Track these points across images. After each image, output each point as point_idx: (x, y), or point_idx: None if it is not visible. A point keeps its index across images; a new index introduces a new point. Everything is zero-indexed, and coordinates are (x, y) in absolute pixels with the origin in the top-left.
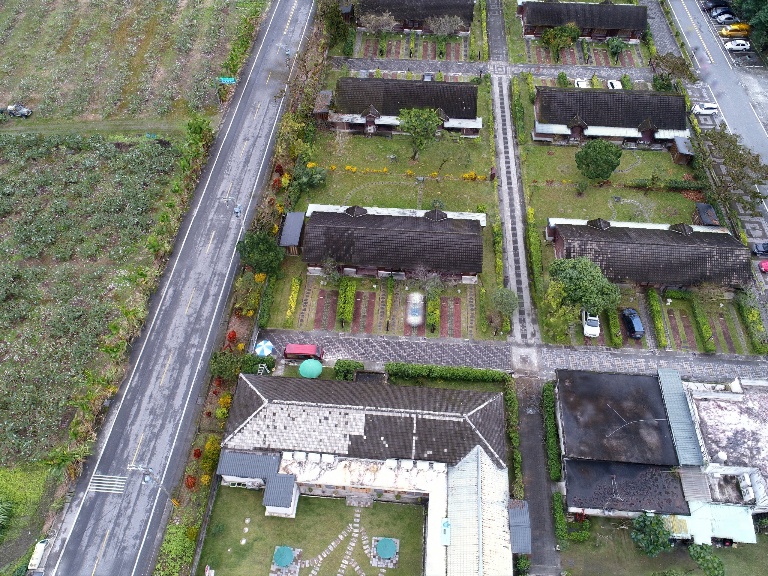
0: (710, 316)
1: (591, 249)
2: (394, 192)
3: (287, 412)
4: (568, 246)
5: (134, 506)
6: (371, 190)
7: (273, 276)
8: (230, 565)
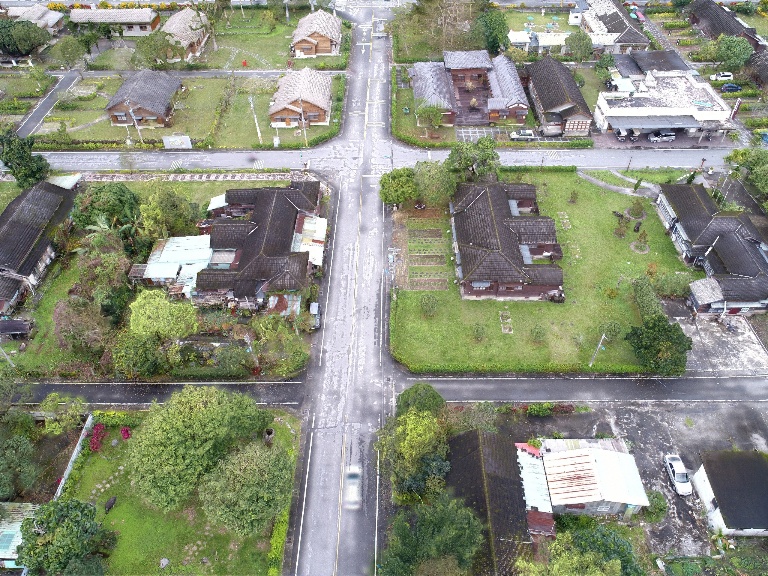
0: (762, 114)
1: (766, 57)
2: (765, 32)
3: (606, 0)
4: (761, 51)
5: (556, 1)
6: (760, 27)
7: (674, 8)
8: (547, 17)
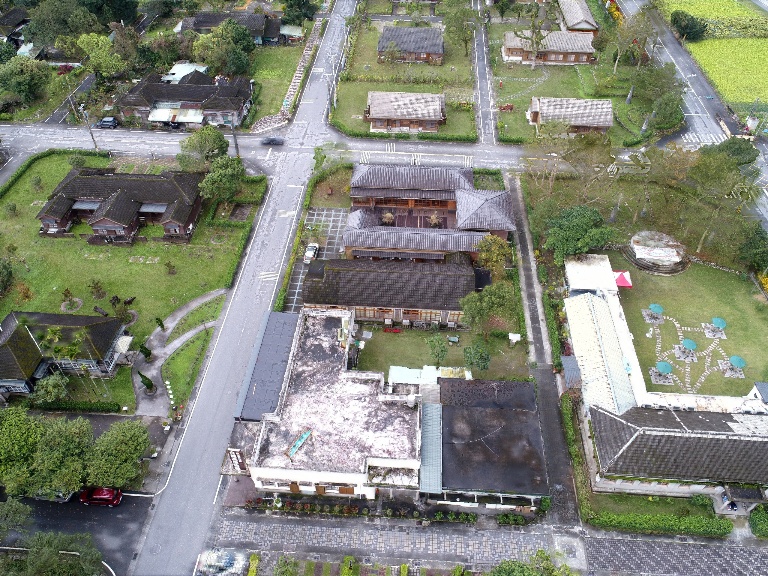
0: None
1: None
2: None
3: None
4: None
5: None
6: None
7: None
8: None
